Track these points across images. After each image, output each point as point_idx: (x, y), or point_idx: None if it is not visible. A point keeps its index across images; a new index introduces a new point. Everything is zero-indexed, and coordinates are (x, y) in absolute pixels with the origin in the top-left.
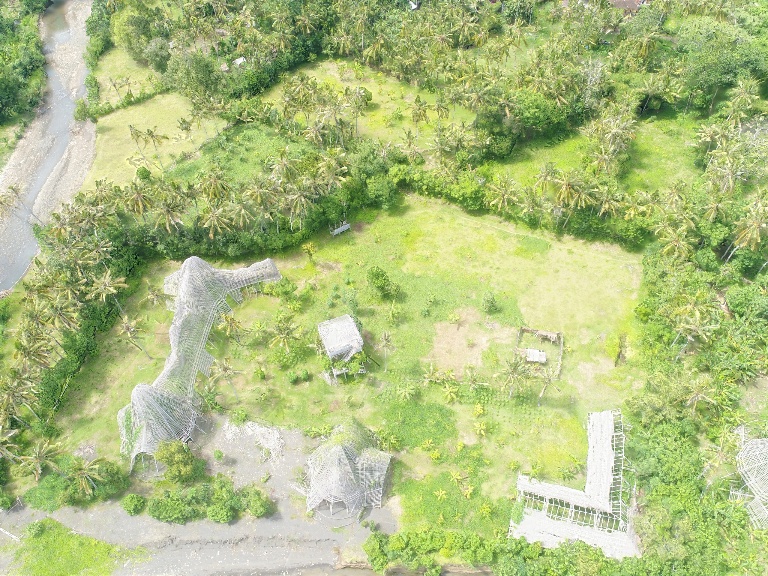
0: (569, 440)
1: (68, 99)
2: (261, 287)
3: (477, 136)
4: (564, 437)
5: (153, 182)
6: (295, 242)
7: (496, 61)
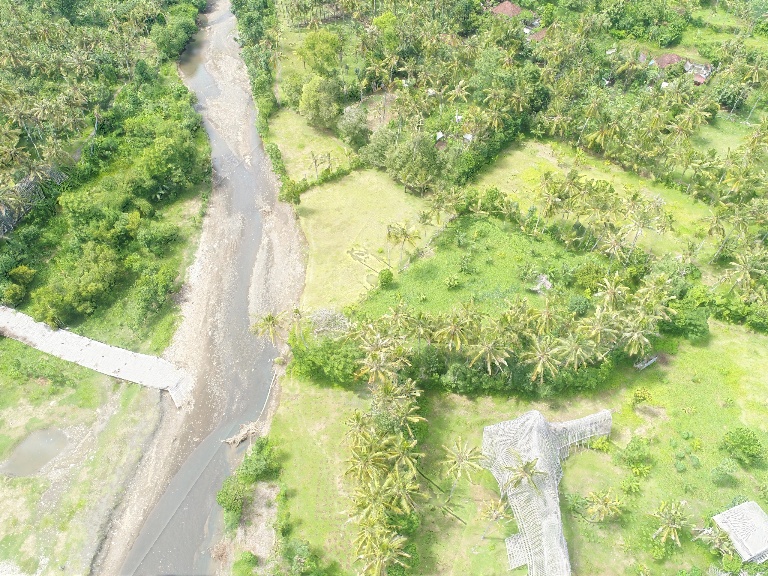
0: None
1: (243, 168)
2: (590, 442)
3: (767, 251)
4: None
5: (391, 284)
6: (604, 379)
7: (758, 161)
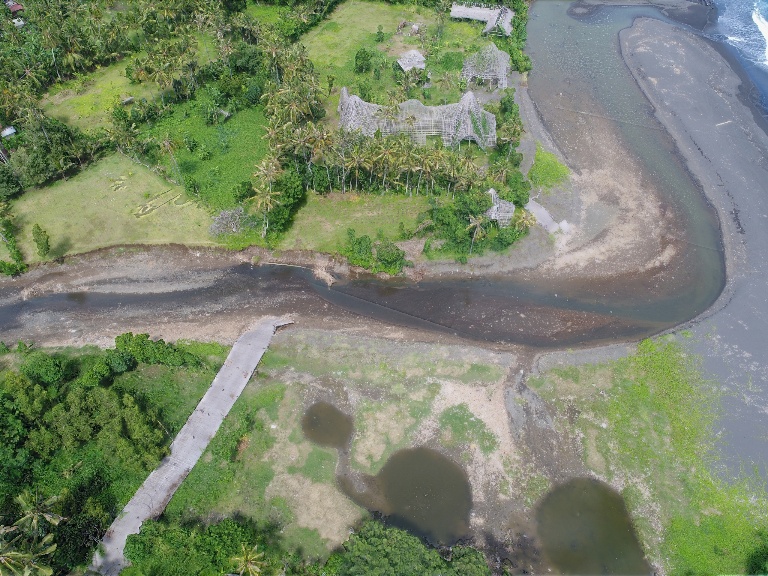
0: (460, 27)
1: None
2: None
3: None
4: (458, 29)
5: None
6: None
7: None
